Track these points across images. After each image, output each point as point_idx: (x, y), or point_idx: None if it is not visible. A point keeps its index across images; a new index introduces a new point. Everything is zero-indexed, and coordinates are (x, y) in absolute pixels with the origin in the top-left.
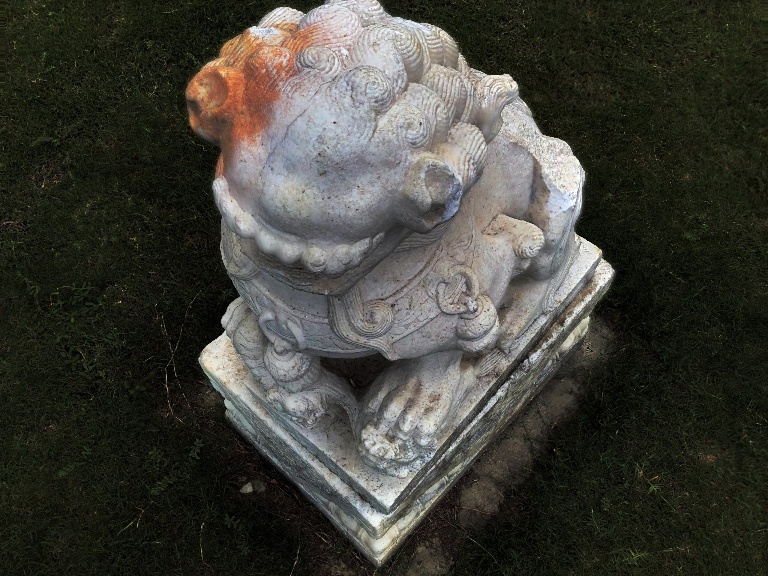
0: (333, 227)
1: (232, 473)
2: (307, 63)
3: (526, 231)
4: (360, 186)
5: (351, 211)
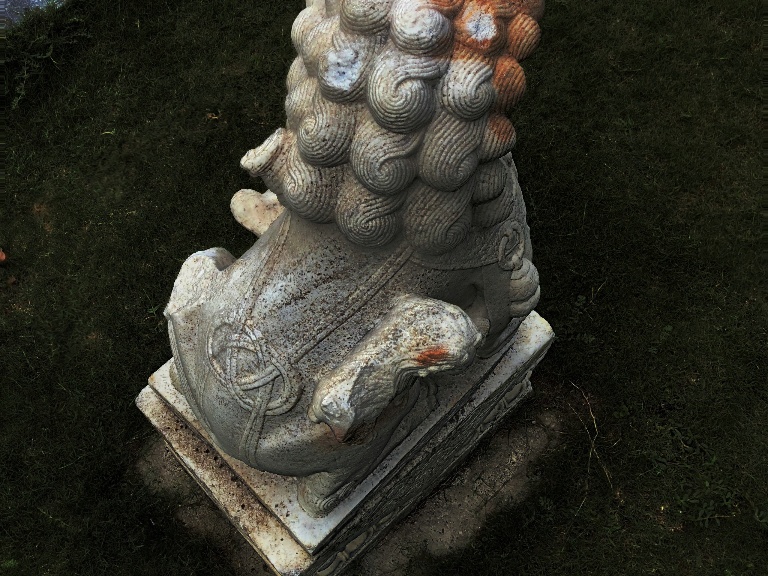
0: None
1: None
2: None
3: (247, 198)
4: None
5: None
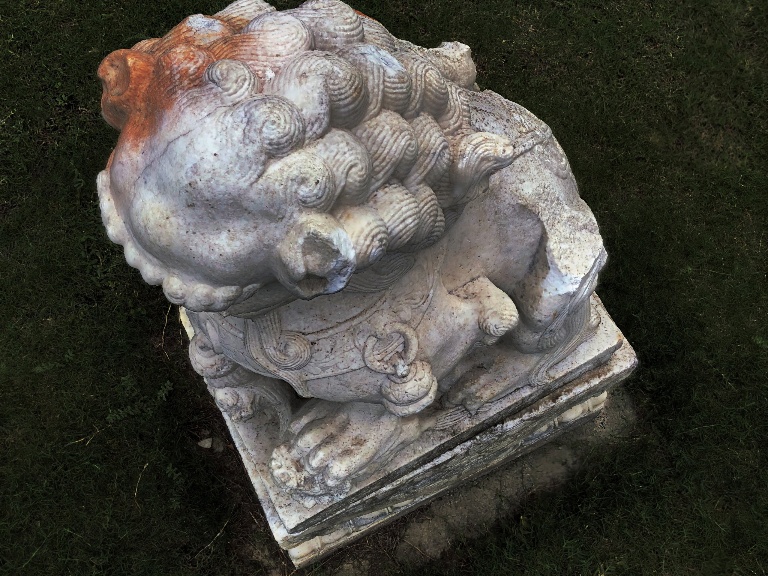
0: (195, 264)
1: (197, 423)
2: (214, 77)
3: (497, 306)
4: (231, 230)
5: (214, 254)
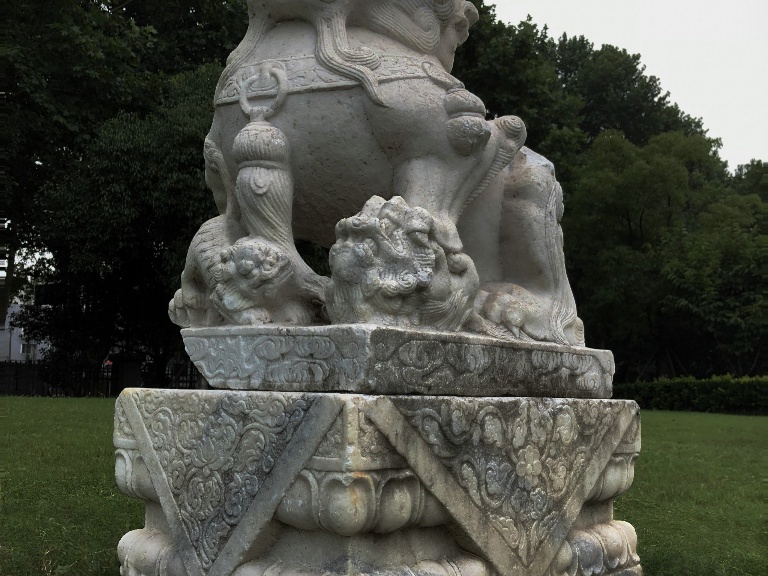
0: None
1: None
2: None
3: None
4: None
5: None
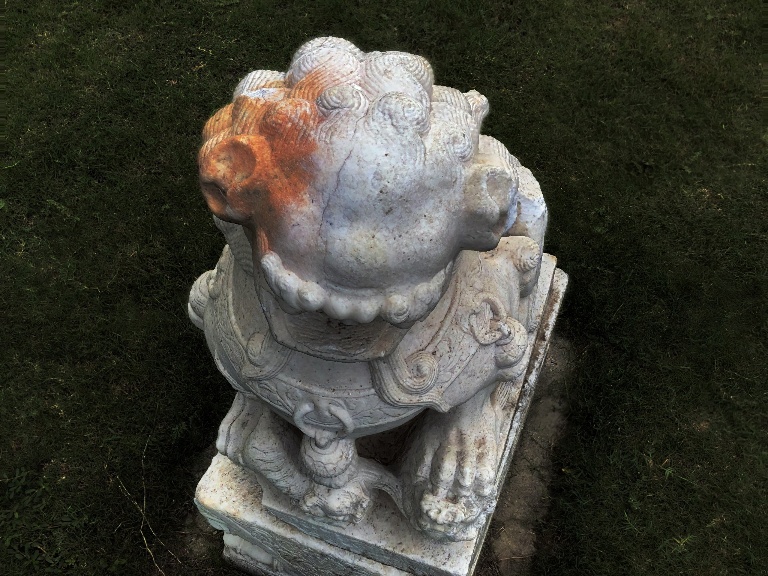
0: (410, 267)
1: None
2: (332, 105)
3: (521, 243)
4: (426, 215)
5: (425, 243)
